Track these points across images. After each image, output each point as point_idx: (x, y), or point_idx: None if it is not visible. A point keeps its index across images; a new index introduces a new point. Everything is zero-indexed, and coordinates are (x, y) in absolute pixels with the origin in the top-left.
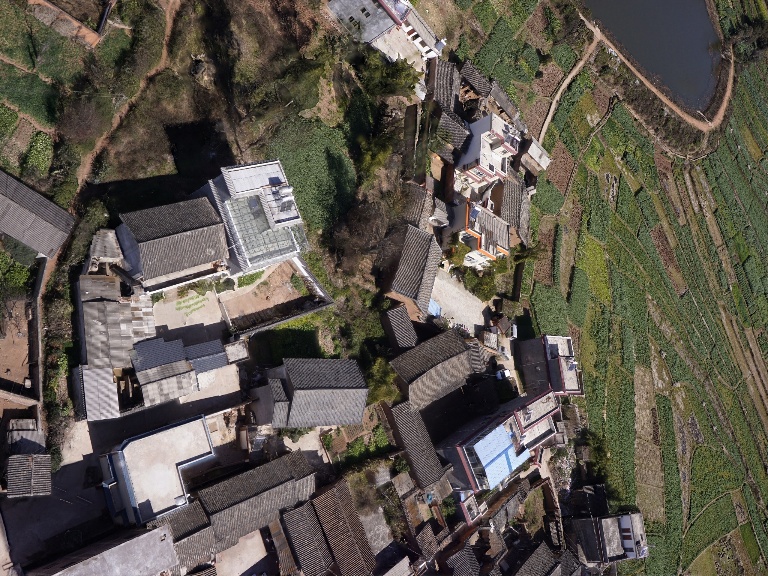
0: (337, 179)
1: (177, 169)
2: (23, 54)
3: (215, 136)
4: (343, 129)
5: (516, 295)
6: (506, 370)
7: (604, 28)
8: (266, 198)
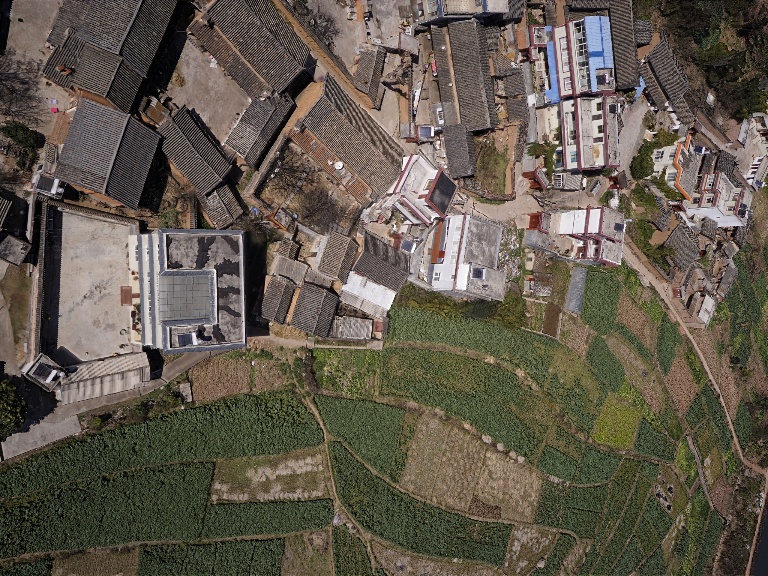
0: None
1: None
2: None
3: None
4: None
5: None
6: None
7: (767, 505)
8: None
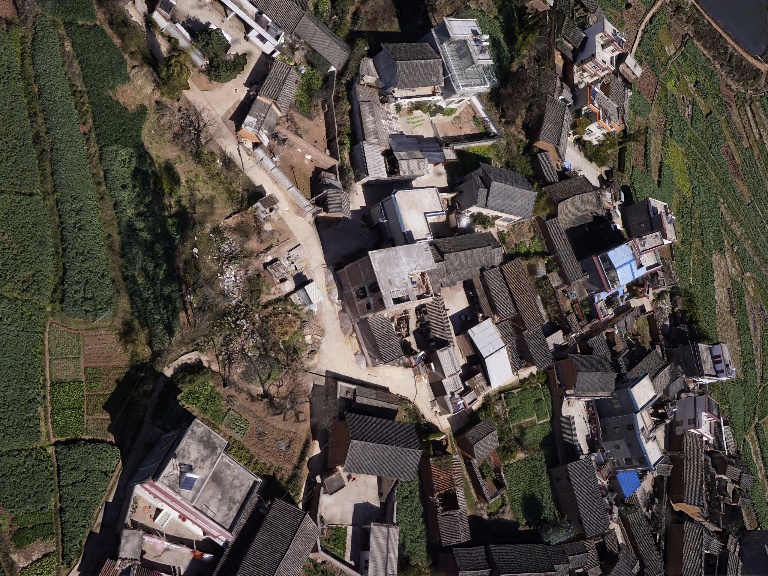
0: (497, 55)
1: (400, 29)
2: None
3: (424, 8)
4: (499, 20)
5: (621, 171)
6: (617, 224)
7: None
8: (470, 43)
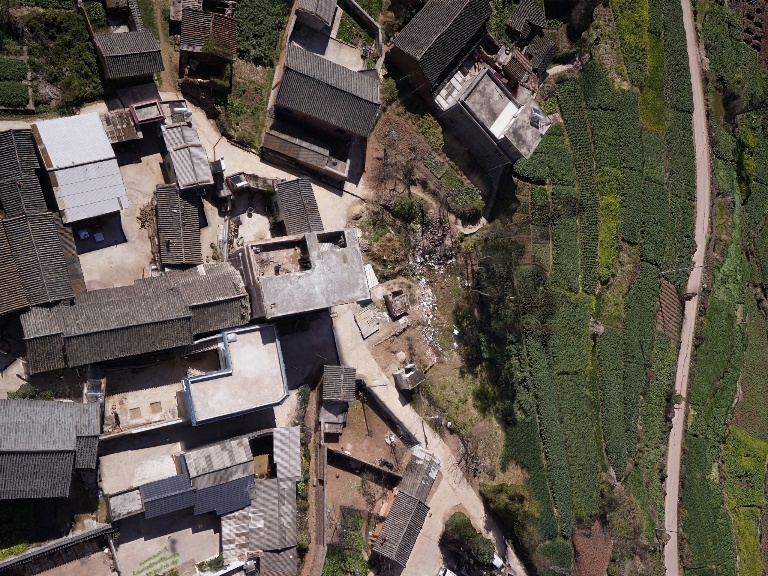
0: None
1: None
2: None
3: None
4: None
5: None
6: None
7: None
8: None
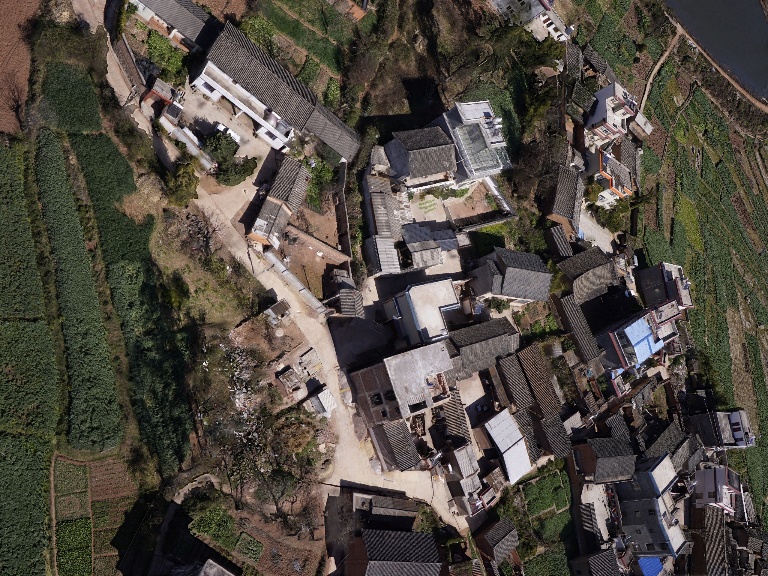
0: (509, 127)
1: (411, 110)
2: (320, 24)
3: (434, 87)
4: (509, 90)
5: (634, 233)
6: (632, 290)
7: (683, 25)
8: (483, 126)
